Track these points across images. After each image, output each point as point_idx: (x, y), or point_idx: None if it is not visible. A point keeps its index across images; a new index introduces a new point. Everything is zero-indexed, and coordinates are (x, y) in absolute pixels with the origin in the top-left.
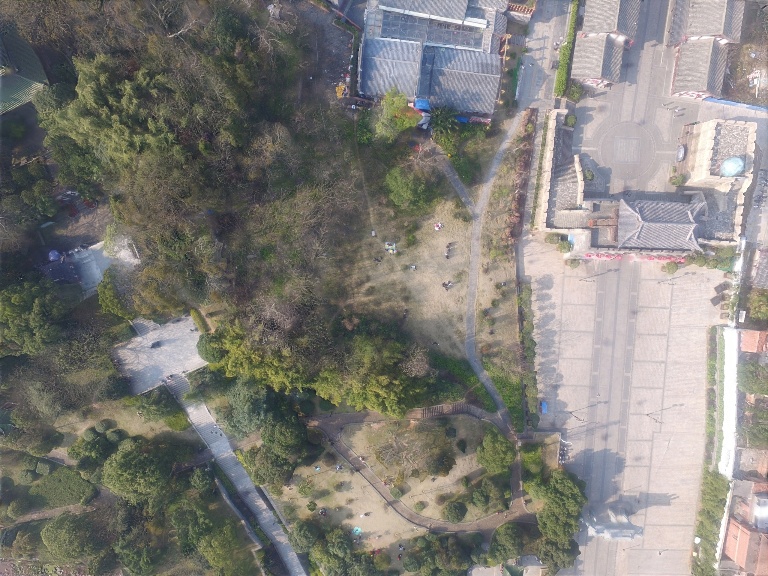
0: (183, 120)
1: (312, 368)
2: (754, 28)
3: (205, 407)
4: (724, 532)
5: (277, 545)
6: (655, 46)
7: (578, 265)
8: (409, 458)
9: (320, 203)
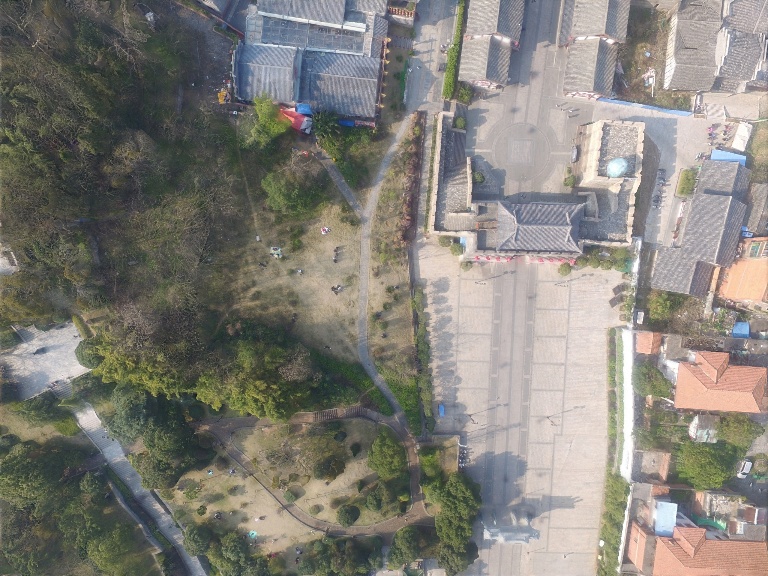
0: (41, 129)
1: (186, 373)
2: (648, 27)
3: (94, 412)
4: (625, 535)
5: (179, 548)
6: (548, 47)
7: None
8: (302, 462)
9: (202, 209)
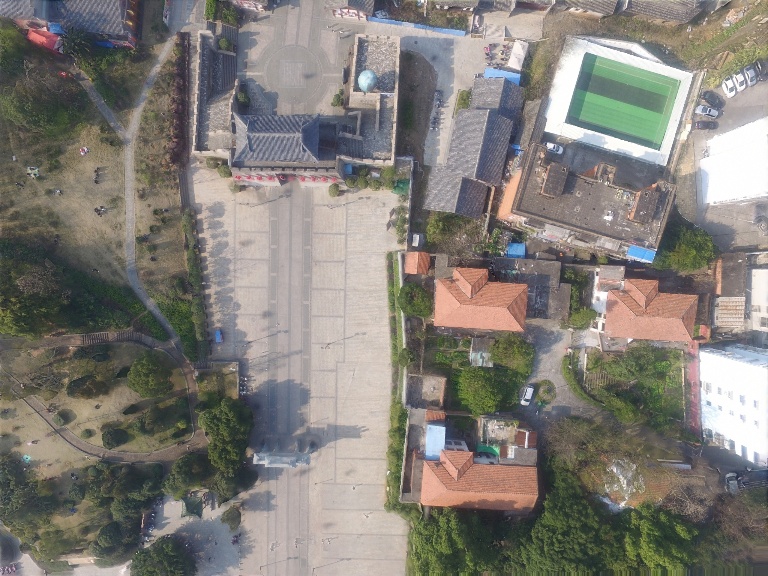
0: None
1: None
2: None
3: None
4: (403, 463)
5: None
6: None
7: (239, 190)
8: None
9: None
